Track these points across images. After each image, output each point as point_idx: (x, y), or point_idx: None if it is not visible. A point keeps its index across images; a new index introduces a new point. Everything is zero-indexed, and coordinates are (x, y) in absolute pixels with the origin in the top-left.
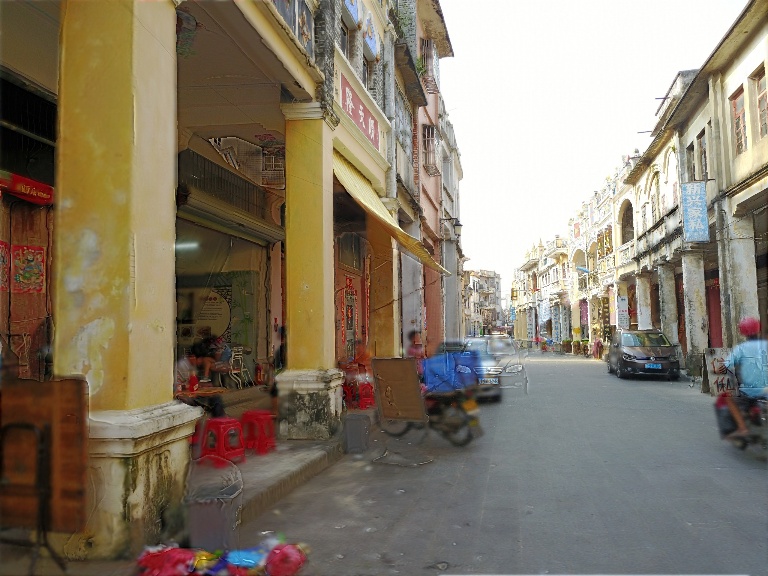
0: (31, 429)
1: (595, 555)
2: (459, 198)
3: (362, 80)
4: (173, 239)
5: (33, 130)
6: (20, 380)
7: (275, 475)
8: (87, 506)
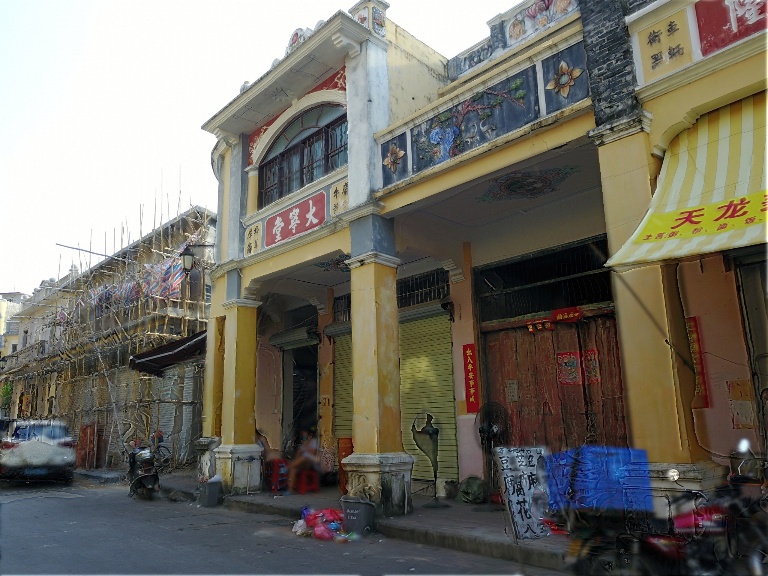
0: None
1: (206, 571)
2: None
3: None
4: None
5: (566, 274)
6: None
7: (467, 533)
8: None
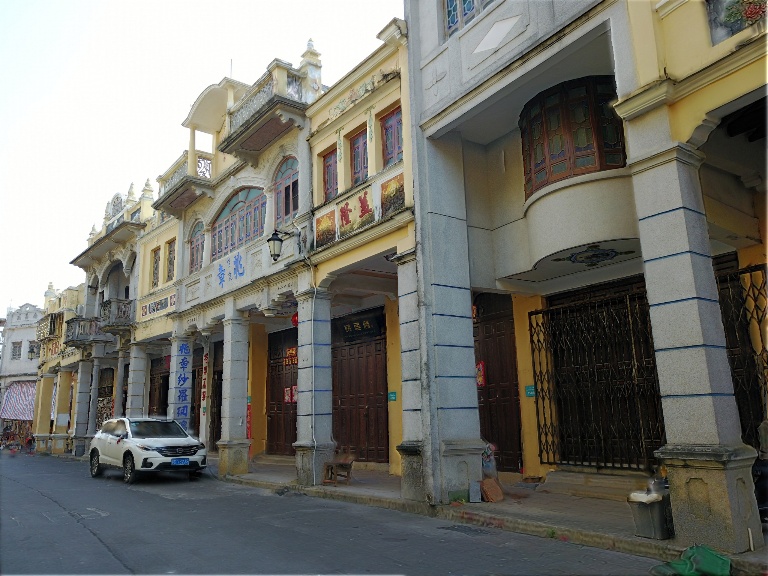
0: None
1: None
2: (6, 341)
3: None
4: None
5: None
6: None
7: None
8: None
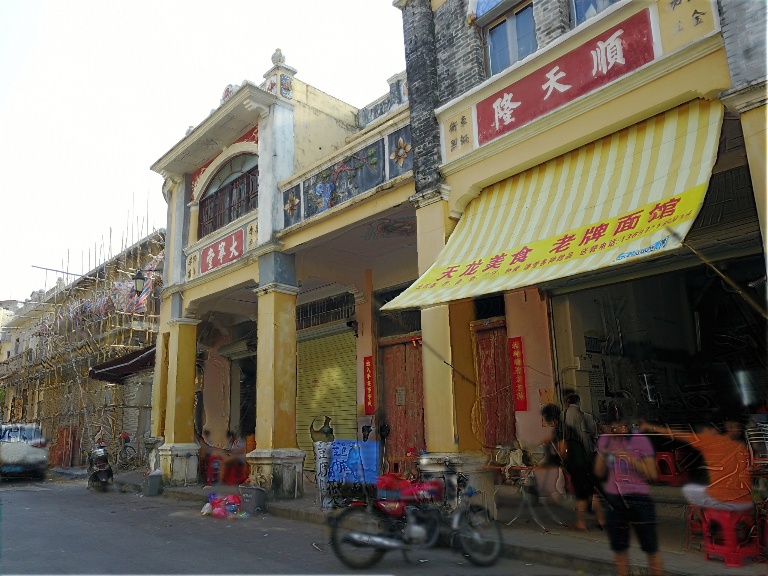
0: None
1: None
2: None
3: None
4: None
5: None
6: None
7: None
8: None
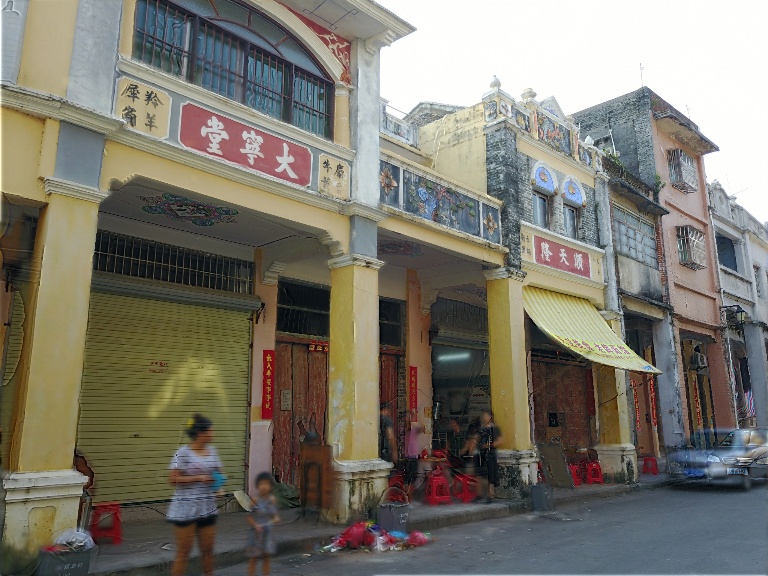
0: (316, 465)
1: None
2: None
3: (570, 225)
4: (377, 380)
5: None
6: (313, 445)
7: (456, 511)
8: (333, 498)
